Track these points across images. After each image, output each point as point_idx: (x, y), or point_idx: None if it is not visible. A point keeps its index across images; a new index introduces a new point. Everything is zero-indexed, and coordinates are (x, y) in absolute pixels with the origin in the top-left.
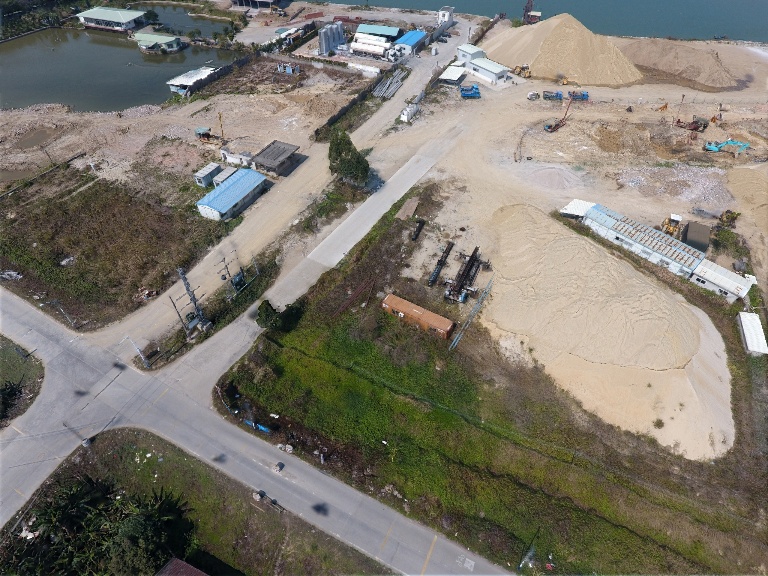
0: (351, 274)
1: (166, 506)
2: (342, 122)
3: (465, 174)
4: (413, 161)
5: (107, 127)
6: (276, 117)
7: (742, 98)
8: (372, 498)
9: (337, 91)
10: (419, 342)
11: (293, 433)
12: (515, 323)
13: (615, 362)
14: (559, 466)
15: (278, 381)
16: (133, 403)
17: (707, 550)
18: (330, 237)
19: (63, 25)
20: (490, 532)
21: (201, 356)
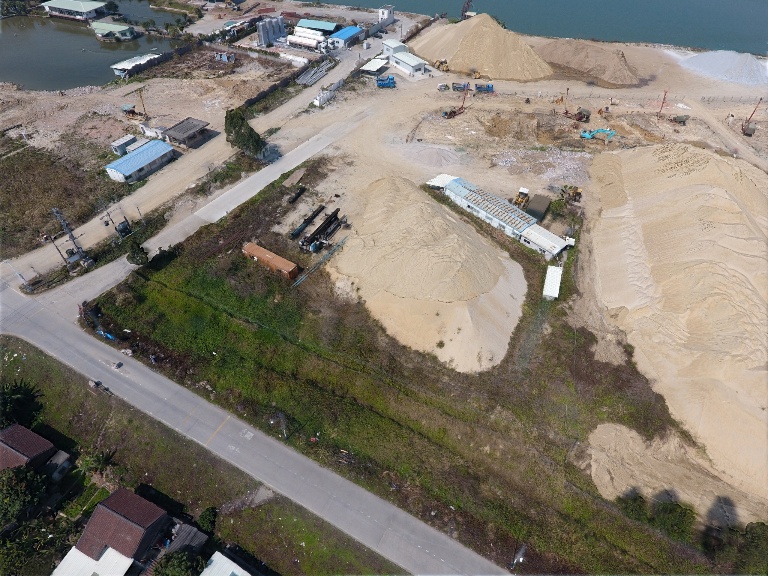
0: (226, 228)
1: (22, 391)
2: (259, 104)
3: (357, 151)
4: (314, 139)
5: (49, 104)
6: (202, 99)
7: (635, 94)
8: (187, 389)
9: (264, 78)
10: (264, 280)
11: (139, 343)
12: (351, 268)
13: (416, 296)
14: (349, 373)
15: (139, 306)
16: (11, 317)
17: (449, 435)
18: (219, 199)
19: (29, 13)
20: (273, 414)
21: (78, 285)
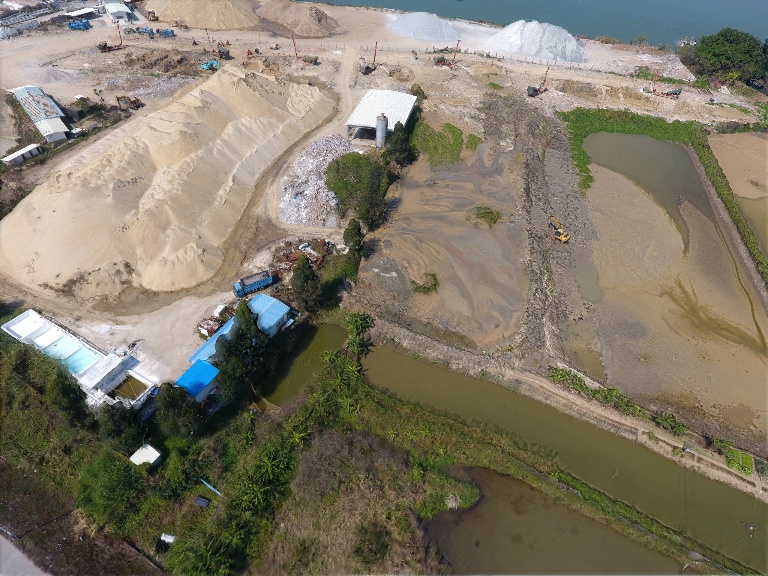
0: None
1: None
2: None
3: None
4: None
5: None
6: None
7: None
8: None
9: None
10: None
11: None
12: None
13: None
14: None
15: None
16: None
17: None
18: None
19: None
20: None
21: None
